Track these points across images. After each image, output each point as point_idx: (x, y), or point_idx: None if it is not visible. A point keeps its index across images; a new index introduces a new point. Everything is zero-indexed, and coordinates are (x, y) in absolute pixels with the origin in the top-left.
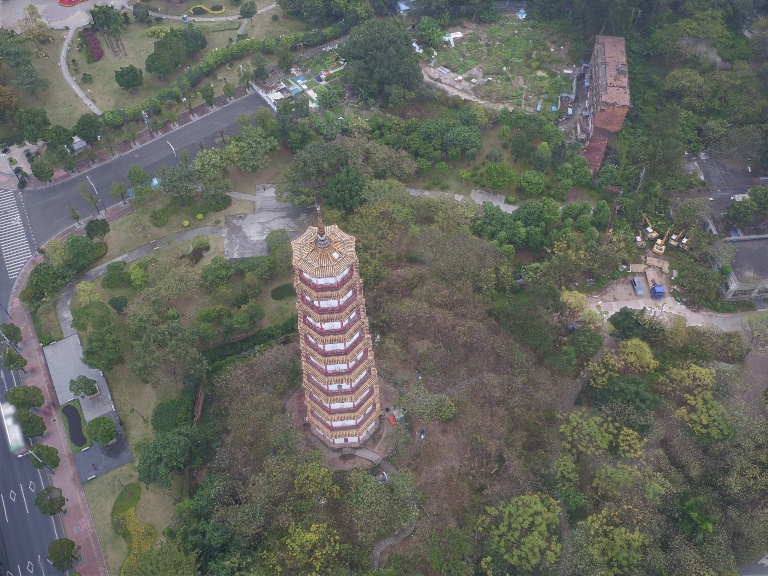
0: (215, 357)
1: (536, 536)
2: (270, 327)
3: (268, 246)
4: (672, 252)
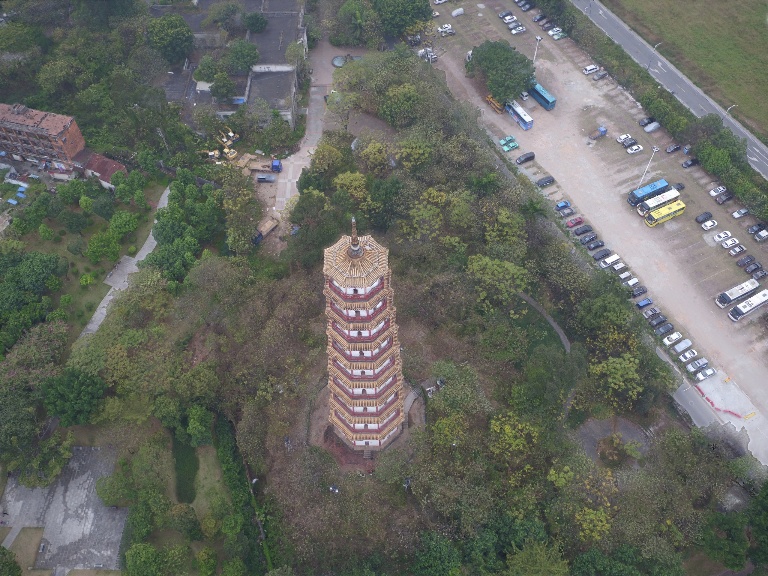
0: (260, 571)
1: (509, 265)
2: (233, 504)
3: (118, 500)
4: (236, 148)
